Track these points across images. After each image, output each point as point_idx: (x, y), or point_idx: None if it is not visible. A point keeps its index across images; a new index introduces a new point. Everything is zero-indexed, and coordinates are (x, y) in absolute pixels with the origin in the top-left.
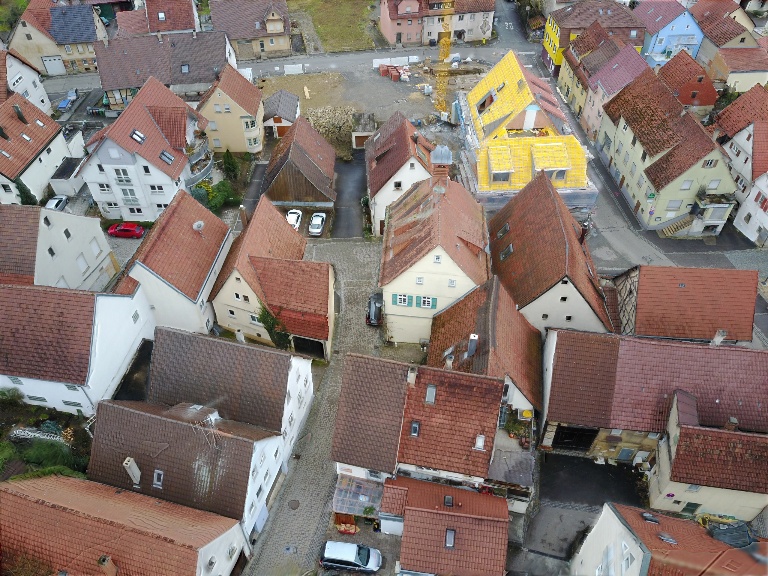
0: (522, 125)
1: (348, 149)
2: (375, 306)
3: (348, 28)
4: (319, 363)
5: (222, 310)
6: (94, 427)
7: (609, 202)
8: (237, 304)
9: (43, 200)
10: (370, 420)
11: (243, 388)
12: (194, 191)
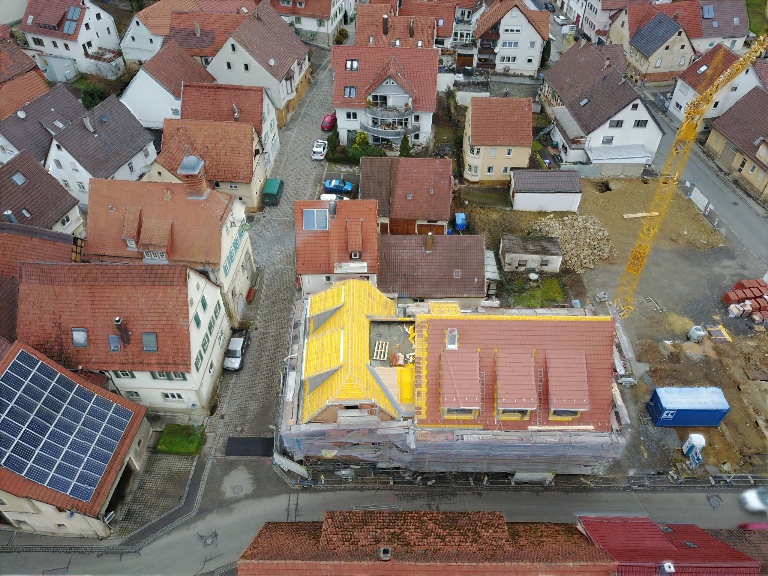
0: None
1: (497, 248)
2: None
3: None
4: None
5: None
6: None
7: None
8: None
9: None
10: None
11: None
12: (351, 131)
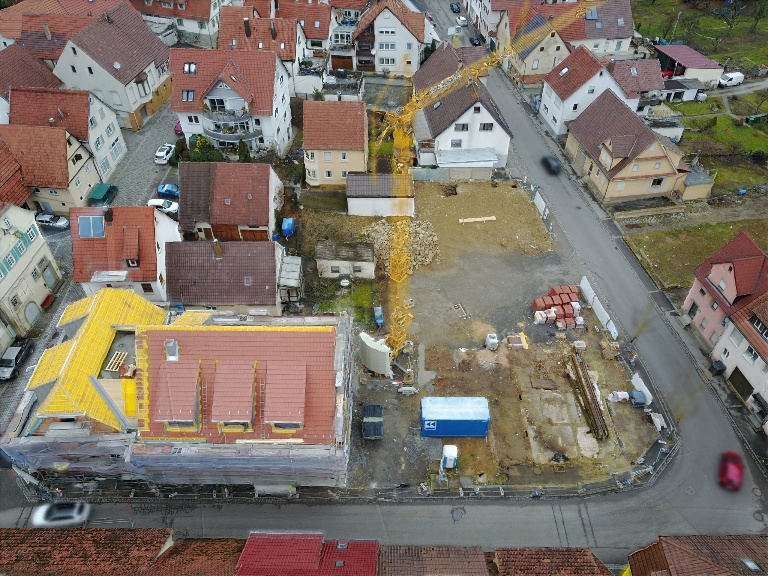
0: None
1: None
2: None
3: None
4: None
5: None
6: None
7: None
8: None
9: None
10: None
11: None
12: (192, 135)
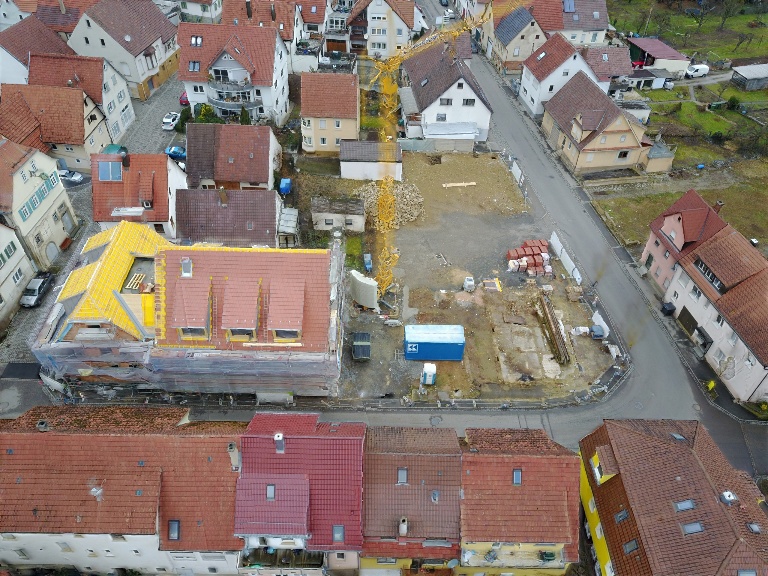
0: None
1: None
2: None
3: None
4: None
5: None
6: None
7: None
8: None
9: None
10: None
11: None
12: None
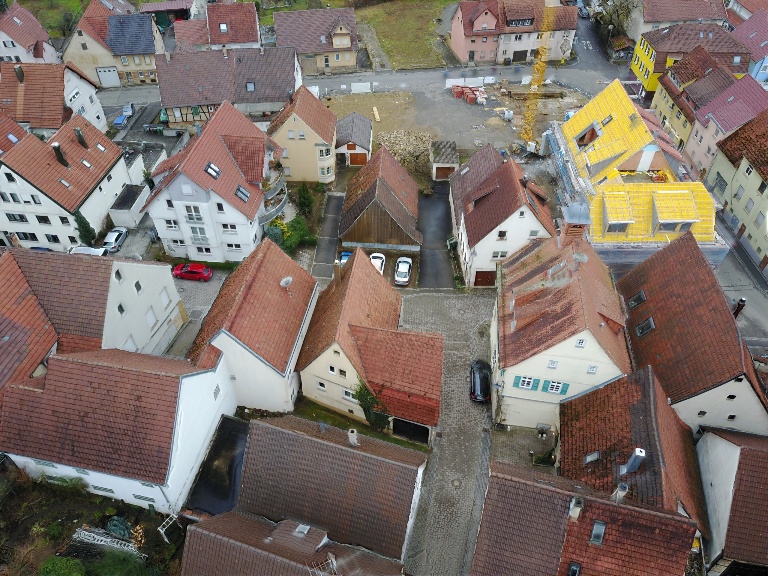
0: (636, 166)
1: (427, 181)
2: (480, 378)
3: (415, 43)
4: (421, 448)
5: (310, 381)
6: (170, 530)
7: (728, 254)
8: (330, 377)
9: (101, 233)
10: (518, 558)
11: (356, 503)
12: (269, 230)
